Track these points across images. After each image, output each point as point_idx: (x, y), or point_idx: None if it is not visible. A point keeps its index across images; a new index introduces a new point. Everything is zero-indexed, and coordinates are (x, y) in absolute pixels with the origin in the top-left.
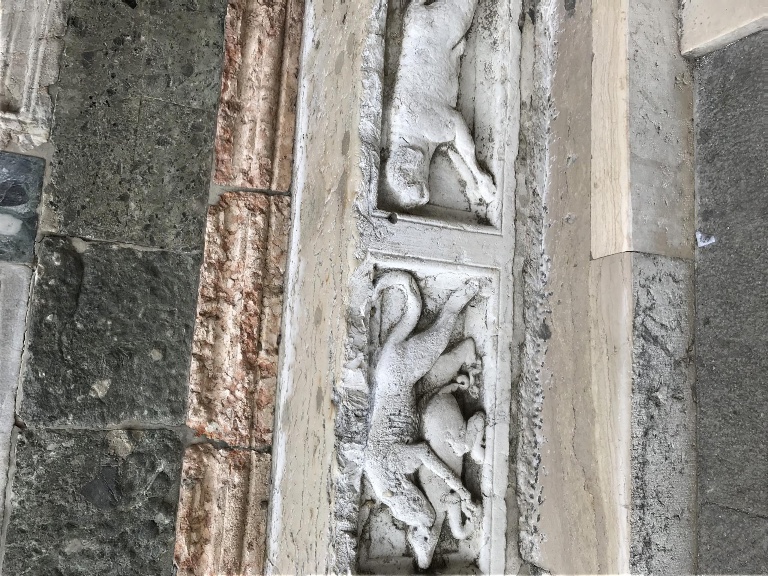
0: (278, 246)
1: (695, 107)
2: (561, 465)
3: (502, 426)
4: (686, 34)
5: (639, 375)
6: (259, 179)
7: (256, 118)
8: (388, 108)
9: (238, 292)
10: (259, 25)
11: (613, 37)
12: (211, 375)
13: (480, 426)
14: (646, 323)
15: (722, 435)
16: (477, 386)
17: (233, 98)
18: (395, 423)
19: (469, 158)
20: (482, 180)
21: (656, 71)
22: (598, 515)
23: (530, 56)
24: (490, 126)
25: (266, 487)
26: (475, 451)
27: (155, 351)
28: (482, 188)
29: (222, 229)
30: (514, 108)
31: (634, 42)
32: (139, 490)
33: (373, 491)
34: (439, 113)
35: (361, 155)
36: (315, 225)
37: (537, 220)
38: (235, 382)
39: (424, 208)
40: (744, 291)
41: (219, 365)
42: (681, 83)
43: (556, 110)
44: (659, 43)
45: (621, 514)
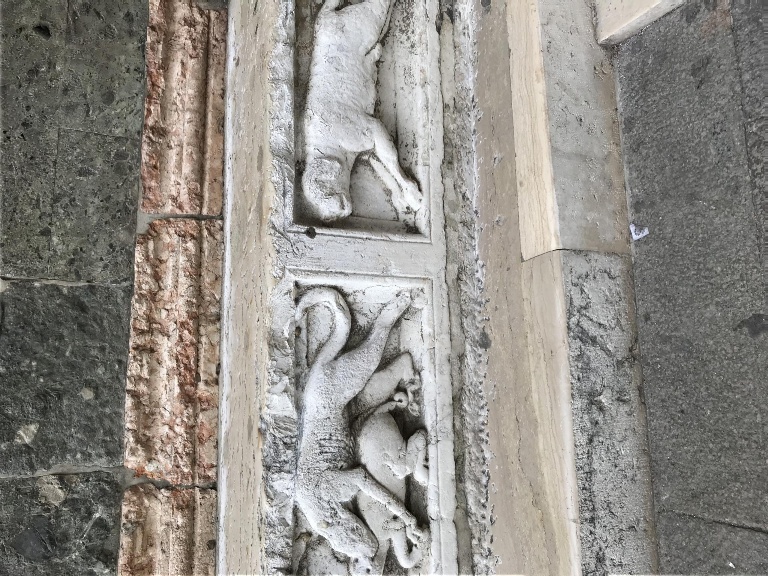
0: (212, 272)
1: (618, 96)
2: (509, 481)
3: (445, 443)
4: (601, 22)
5: (578, 379)
6: (188, 204)
7: (182, 142)
8: (301, 120)
9: (172, 322)
10: (181, 48)
11: (526, 30)
12: (148, 411)
13: (421, 445)
14: (582, 323)
15: (673, 437)
16: (417, 403)
17: (157, 124)
18: (326, 448)
19: (391, 166)
20: (407, 187)
21: (572, 62)
22: (548, 532)
23: (450, 58)
24: (413, 132)
25: (213, 525)
26: (418, 472)
27: (85, 390)
28: (407, 196)
29: (152, 258)
30: (436, 111)
31: (546, 33)
32: (75, 538)
33: (308, 523)
34: (354, 121)
35: (272, 169)
36: (241, 246)
37: (469, 225)
38: (174, 416)
39: (347, 220)
40: (681, 282)
41: (156, 400)
42: (601, 72)
43: (480, 110)
44: (573, 33)
45: (570, 529)
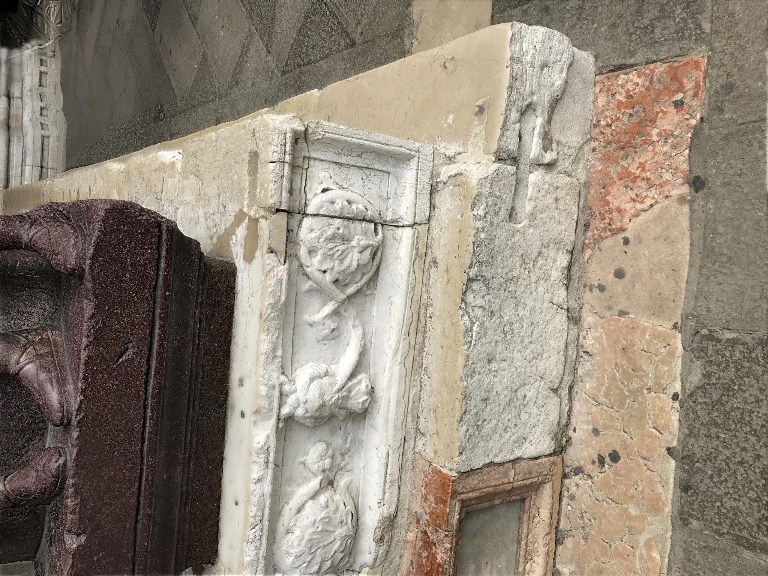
0: None
1: None
2: None
3: None
4: None
5: None
6: None
7: None
8: None
9: None
10: None
11: None
12: None
13: None
14: None
15: None
16: None
17: None
18: None
19: None
20: None
21: None
22: None
23: None
24: None
25: None
26: None
27: None
28: None
29: None
30: None
31: None
32: None
33: None
34: None
35: None
36: None
37: None
38: None
39: None
40: (72, 168)
41: None
42: None
43: None
44: None
45: (60, 174)
